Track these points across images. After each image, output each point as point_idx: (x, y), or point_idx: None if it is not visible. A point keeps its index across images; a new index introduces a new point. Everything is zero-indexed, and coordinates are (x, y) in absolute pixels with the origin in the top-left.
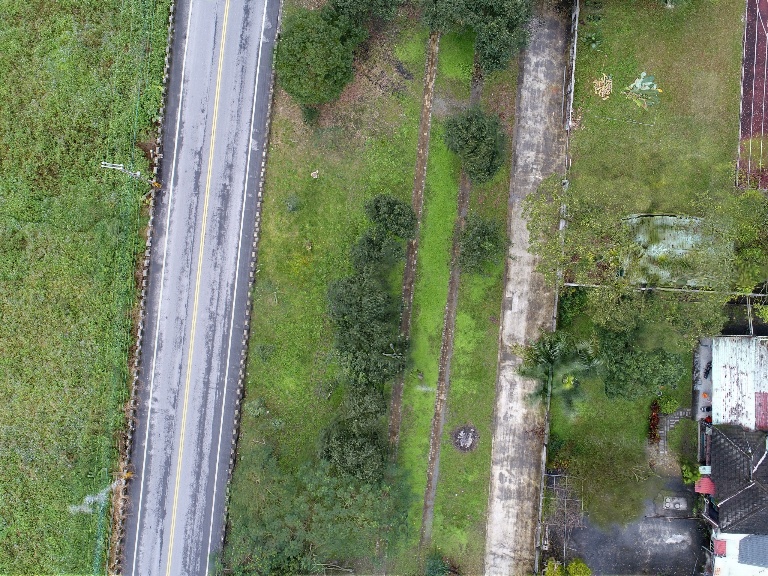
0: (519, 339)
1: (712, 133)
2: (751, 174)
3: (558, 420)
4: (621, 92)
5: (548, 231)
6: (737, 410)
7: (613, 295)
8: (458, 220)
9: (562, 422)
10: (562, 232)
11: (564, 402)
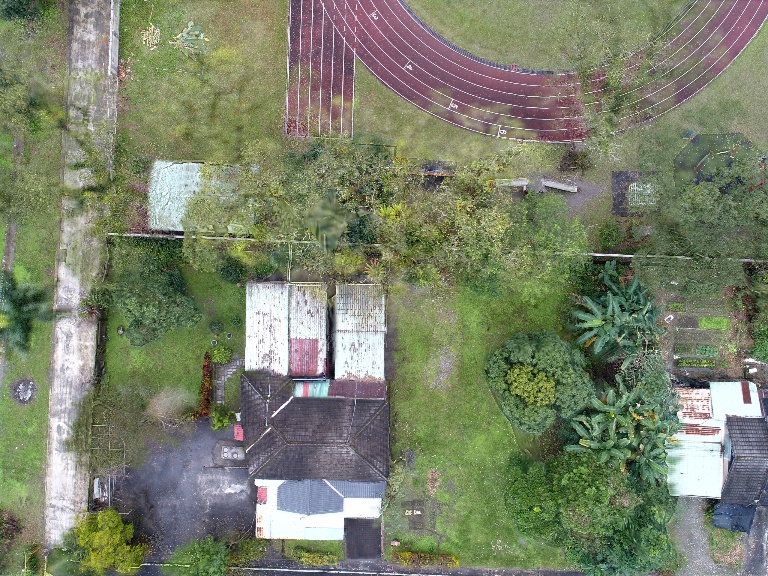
0: (74, 291)
1: (260, 81)
2: (300, 122)
3: (116, 371)
4: (169, 42)
5: (100, 182)
6: (270, 356)
7: (153, 244)
8: (13, 173)
9: (120, 373)
10: (114, 183)
11: (121, 353)
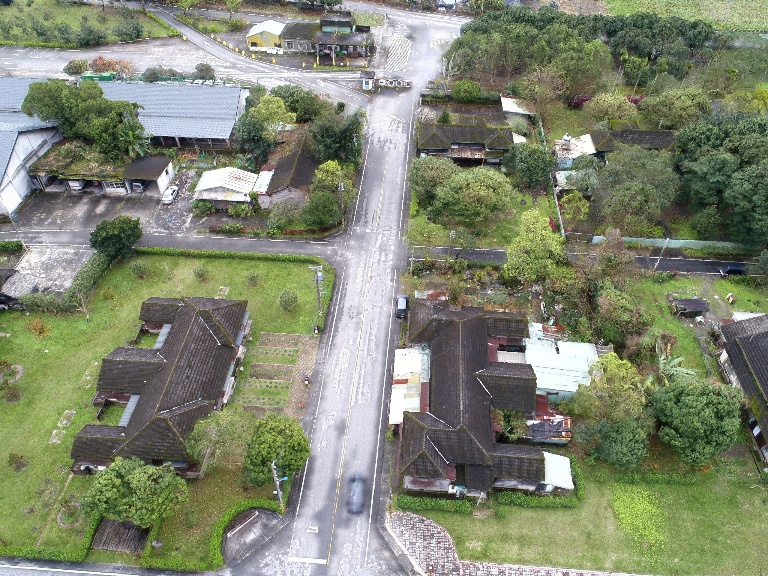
0: None
1: None
2: None
3: None
4: None
5: None
6: None
7: None
8: None
9: None
10: None
11: None
